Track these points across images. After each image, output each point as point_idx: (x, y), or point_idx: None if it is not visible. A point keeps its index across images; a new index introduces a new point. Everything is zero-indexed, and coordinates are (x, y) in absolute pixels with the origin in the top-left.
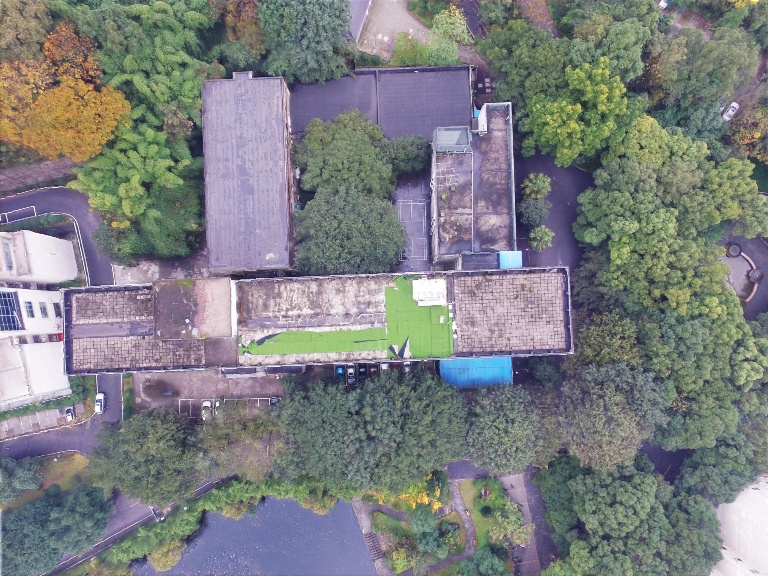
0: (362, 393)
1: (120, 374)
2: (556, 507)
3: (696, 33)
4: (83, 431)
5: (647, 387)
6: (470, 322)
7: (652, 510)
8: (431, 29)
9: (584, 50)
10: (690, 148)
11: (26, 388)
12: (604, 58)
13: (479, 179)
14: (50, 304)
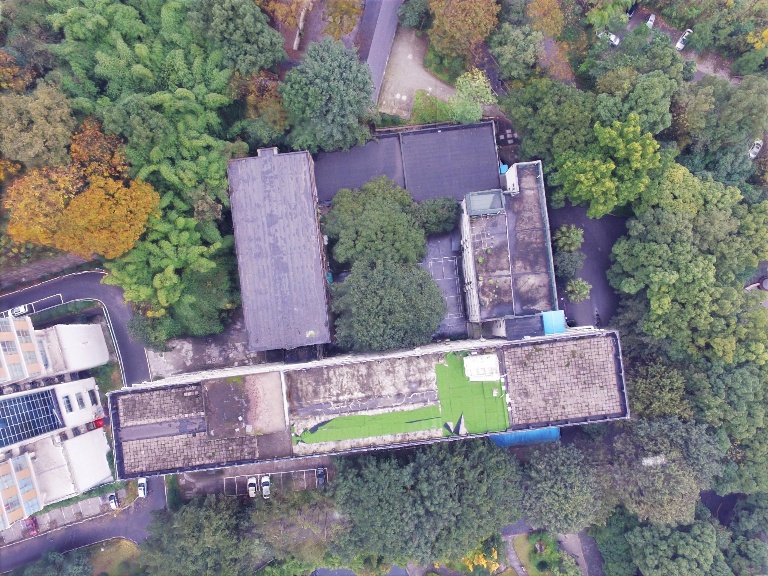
0: (415, 466)
1: None
2: (614, 559)
3: (722, 82)
4: (127, 516)
5: (702, 441)
6: (523, 393)
7: (713, 559)
8: (455, 93)
9: (611, 105)
10: (724, 196)
11: (71, 486)
12: (634, 114)
13: (514, 240)
14: (85, 393)
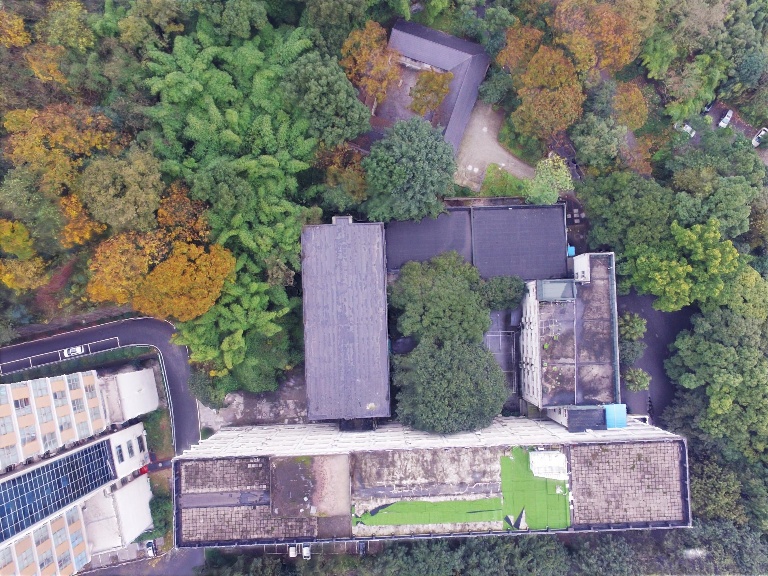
0: (465, 548)
1: None
2: None
3: None
4: (163, 564)
5: (757, 551)
6: (587, 493)
7: None
8: (535, 179)
9: (691, 206)
10: None
11: (118, 539)
12: (714, 219)
13: (581, 328)
14: (135, 440)
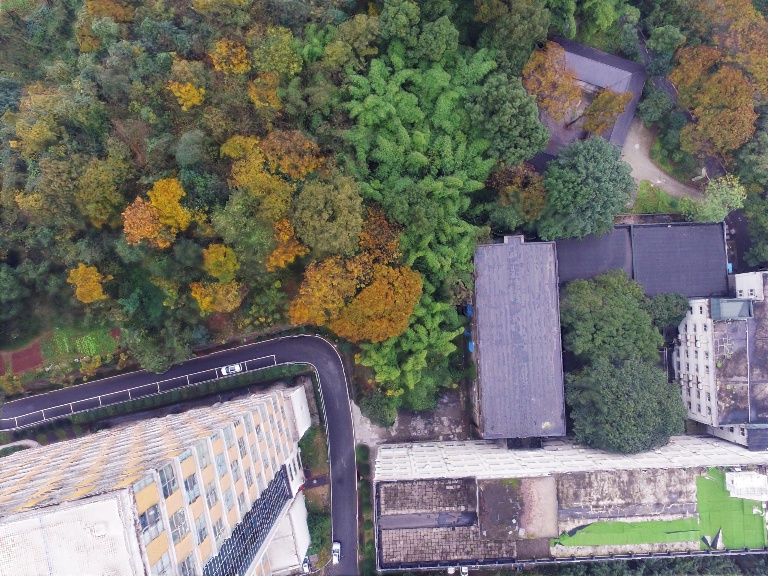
0: None
1: (356, 523)
2: None
3: None
4: None
5: None
6: None
7: None
8: (708, 198)
9: None
10: None
11: (294, 557)
12: None
13: (753, 347)
14: (295, 457)
